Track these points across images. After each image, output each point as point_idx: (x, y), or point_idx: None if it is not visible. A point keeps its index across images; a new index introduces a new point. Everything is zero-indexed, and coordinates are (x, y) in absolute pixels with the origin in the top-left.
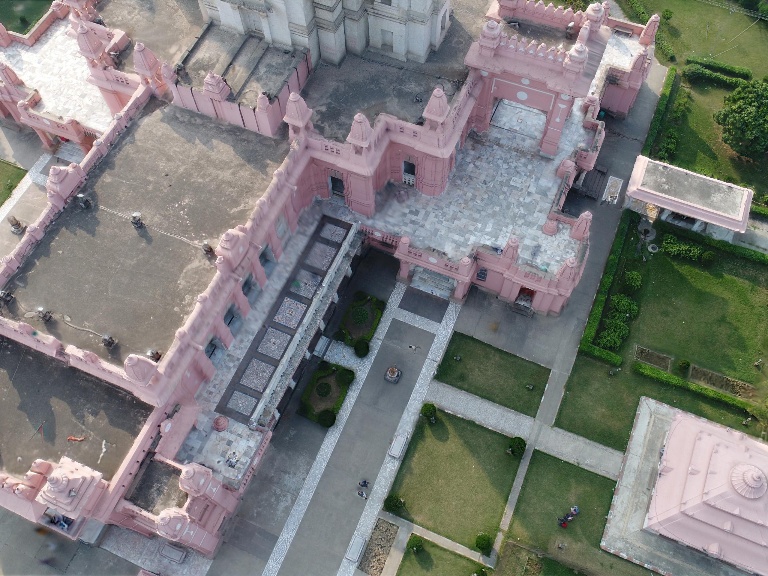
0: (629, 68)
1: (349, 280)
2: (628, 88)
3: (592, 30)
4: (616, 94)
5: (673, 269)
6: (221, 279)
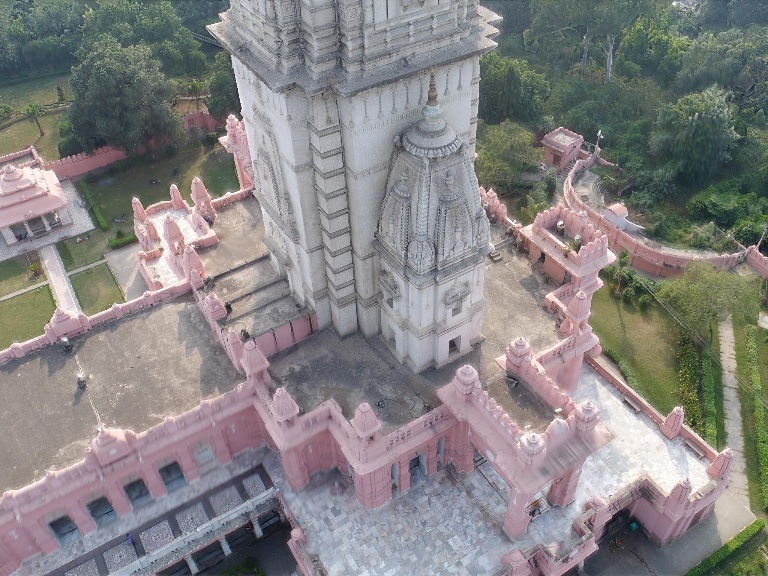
0: (668, 492)
1: (256, 540)
2: (662, 513)
3: (578, 427)
4: (651, 512)
5: None
6: (85, 468)
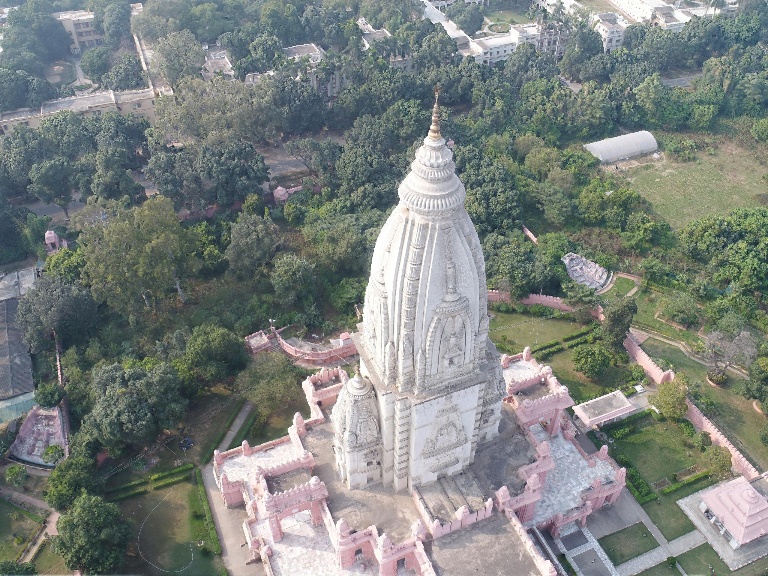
0: None
1: None
2: None
3: None
4: None
5: (627, 443)
6: None
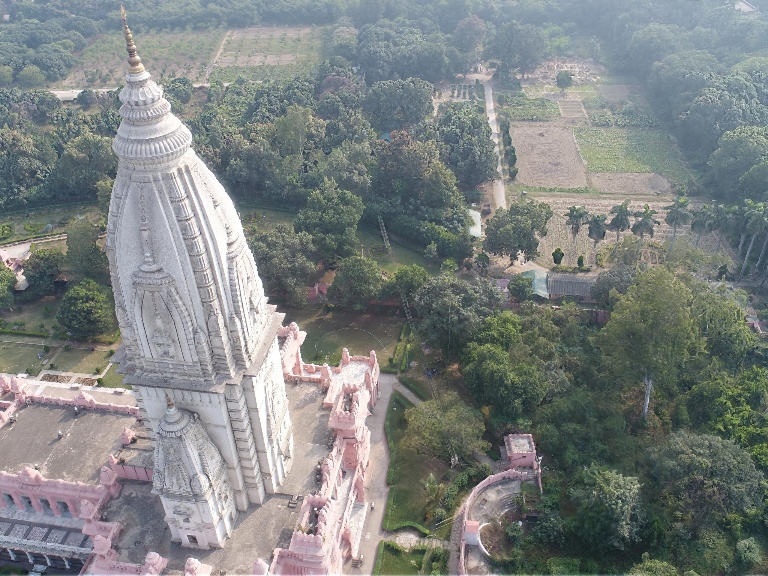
0: None
1: None
2: None
3: None
4: None
5: None
6: None
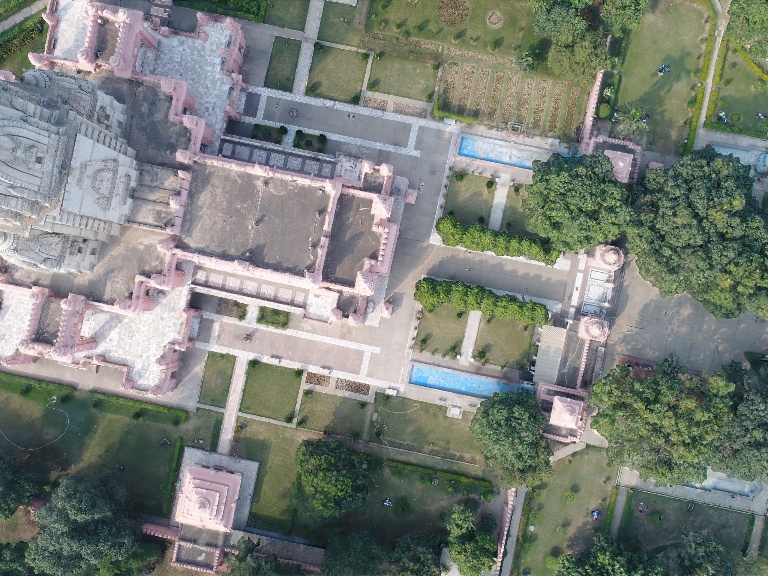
0: (87, 1)
1: None
2: None
3: None
4: None
5: None
6: None
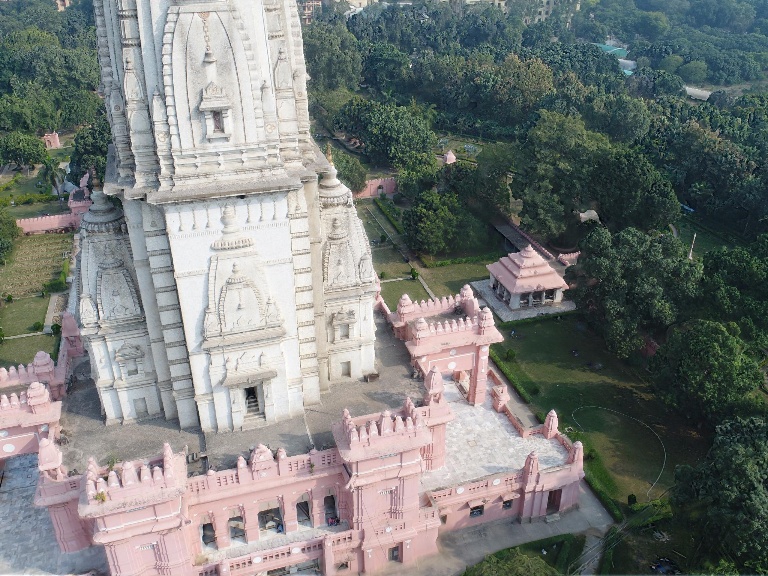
0: None
1: None
2: None
3: None
4: None
5: None
6: None
